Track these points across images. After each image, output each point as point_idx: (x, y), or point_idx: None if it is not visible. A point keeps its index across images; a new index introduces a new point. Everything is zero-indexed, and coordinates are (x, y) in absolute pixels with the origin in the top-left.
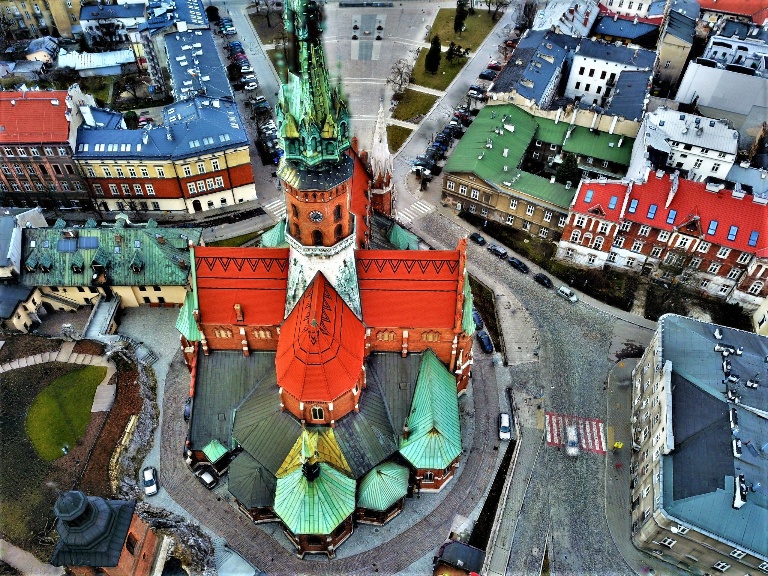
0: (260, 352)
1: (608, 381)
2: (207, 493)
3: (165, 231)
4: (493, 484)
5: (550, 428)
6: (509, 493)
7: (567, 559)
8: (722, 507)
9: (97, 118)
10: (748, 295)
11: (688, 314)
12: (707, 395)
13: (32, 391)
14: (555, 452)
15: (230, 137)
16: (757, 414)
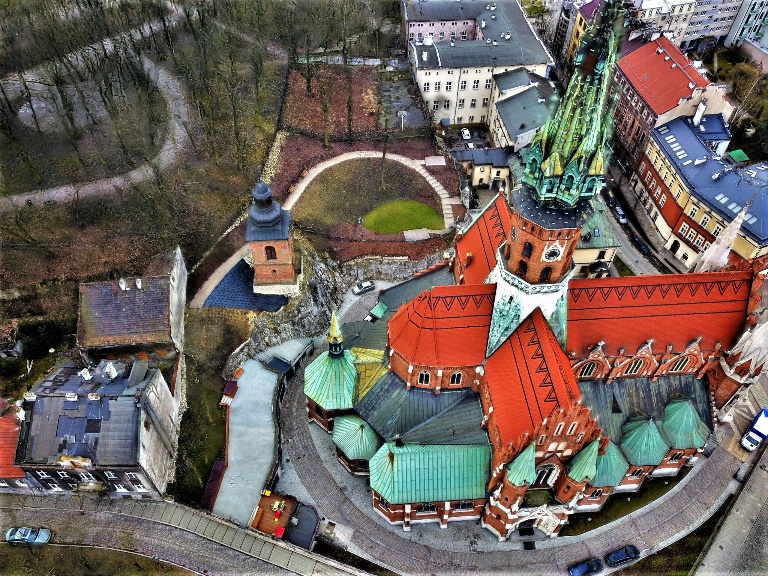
0: None
1: None
2: None
3: (592, 215)
4: (389, 570)
5: None
6: None
7: None
8: None
9: (709, 123)
10: None
11: None
12: None
13: (413, 196)
14: None
15: (755, 223)
16: None
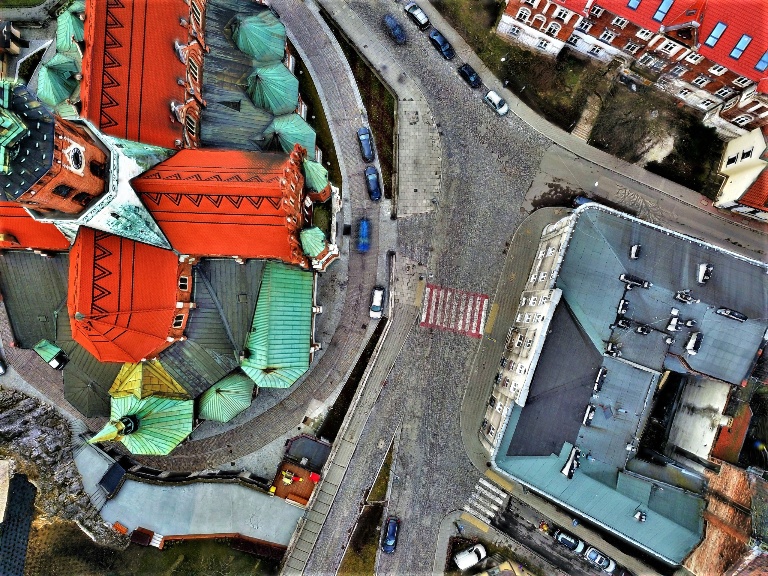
0: (66, 253)
1: (511, 242)
2: (57, 373)
3: None
4: (354, 368)
5: (428, 305)
6: (367, 383)
7: (411, 451)
8: (551, 469)
9: None
10: (730, 124)
11: (646, 136)
12: (586, 341)
13: None
14: (426, 335)
15: None
16: (633, 366)
